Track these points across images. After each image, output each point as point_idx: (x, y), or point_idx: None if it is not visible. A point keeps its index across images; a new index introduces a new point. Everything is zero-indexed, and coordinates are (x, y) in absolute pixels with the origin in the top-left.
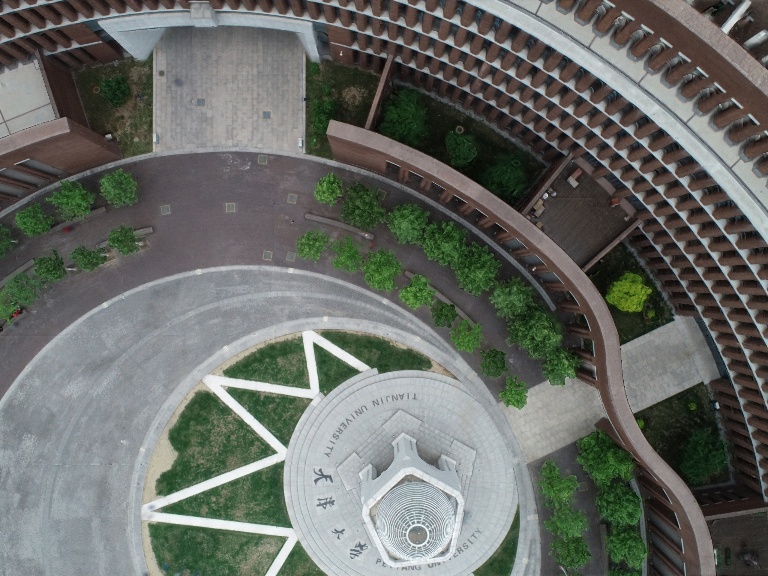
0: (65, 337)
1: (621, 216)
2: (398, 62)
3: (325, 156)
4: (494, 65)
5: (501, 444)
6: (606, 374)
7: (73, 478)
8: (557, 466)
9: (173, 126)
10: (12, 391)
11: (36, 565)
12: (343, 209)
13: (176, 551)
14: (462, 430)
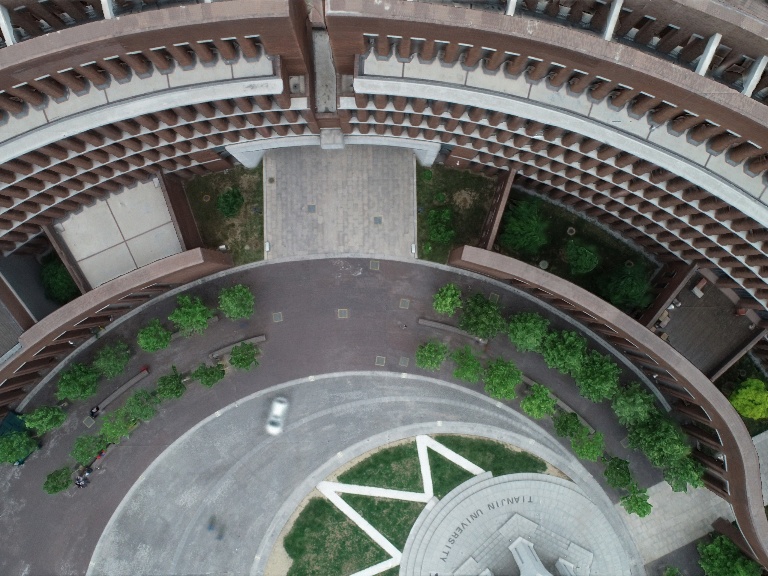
0: (178, 446)
1: (745, 324)
2: (518, 173)
3: (437, 260)
4: (636, 194)
5: (618, 546)
6: (746, 495)
7: None
8: (674, 567)
9: (284, 233)
10: (126, 501)
11: None
12: (460, 317)
13: None
14: (578, 532)
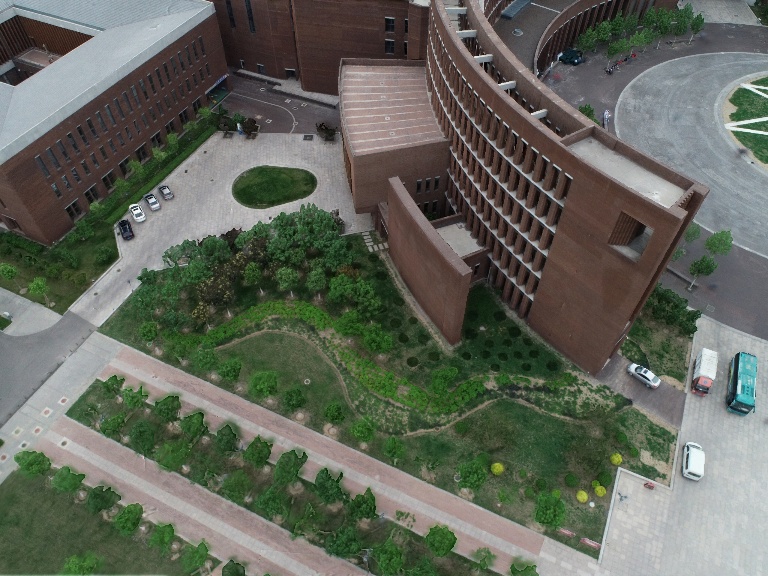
0: (658, 67)
1: None
2: None
3: None
4: None
5: None
6: None
7: (679, 111)
8: None
9: None
10: (634, 81)
11: (667, 141)
12: None
13: (754, 142)
14: None
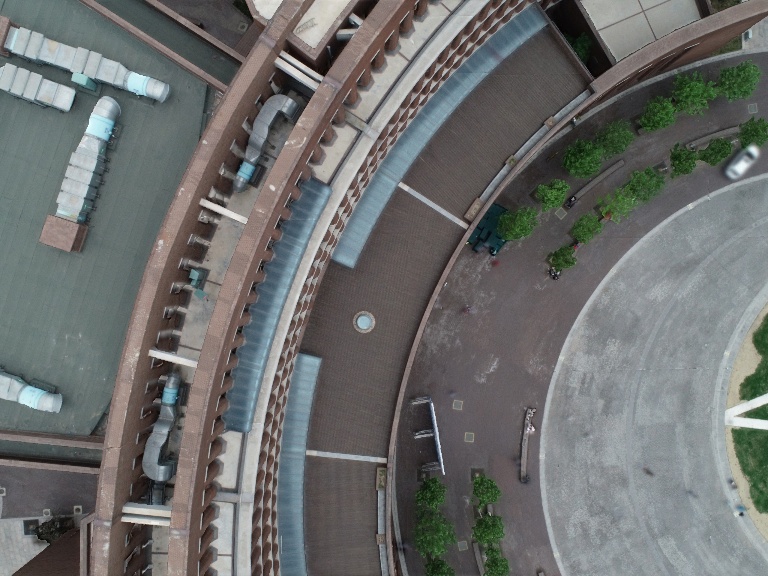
0: (650, 239)
1: None
2: None
3: None
4: None
5: None
6: None
7: (657, 383)
8: None
9: (761, 23)
10: (596, 295)
11: (620, 472)
12: None
13: (760, 456)
14: None
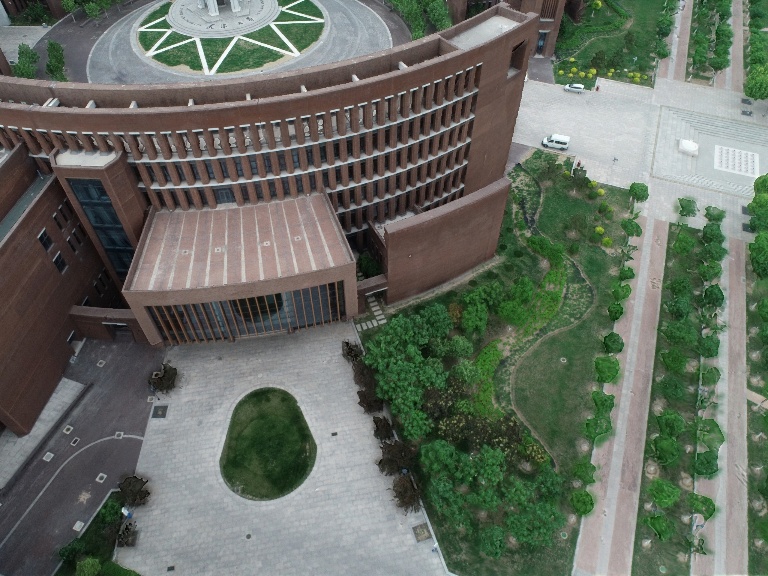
0: None
1: None
2: None
3: (56, 22)
4: None
5: None
6: None
7: None
8: None
9: None
10: None
11: None
12: (82, 8)
13: None
14: None
